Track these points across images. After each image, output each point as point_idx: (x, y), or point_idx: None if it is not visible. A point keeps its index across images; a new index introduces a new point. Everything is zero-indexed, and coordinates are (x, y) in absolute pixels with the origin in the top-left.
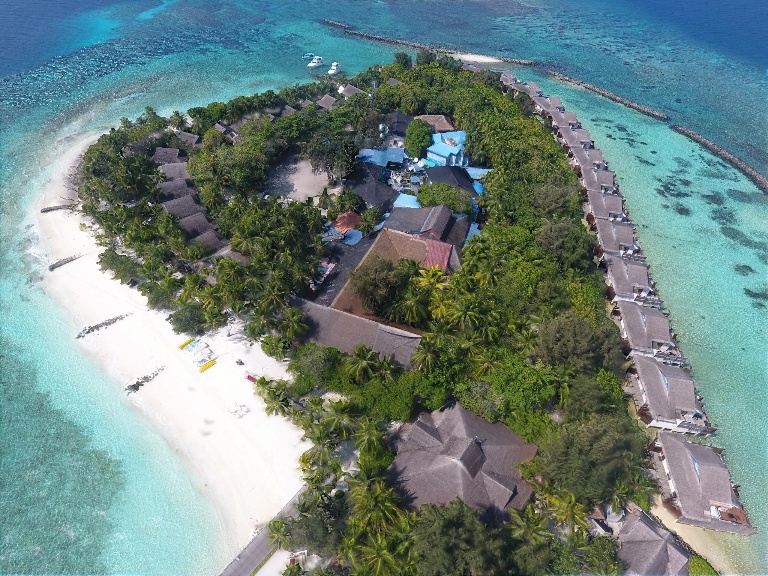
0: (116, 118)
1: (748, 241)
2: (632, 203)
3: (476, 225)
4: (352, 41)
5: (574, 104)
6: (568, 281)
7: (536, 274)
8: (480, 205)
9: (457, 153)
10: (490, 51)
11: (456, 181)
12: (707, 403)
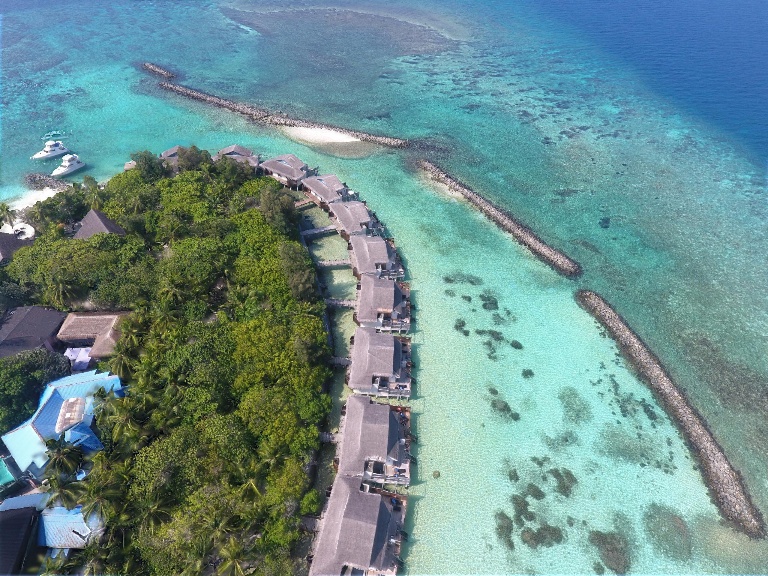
0: None
1: None
2: None
3: None
4: (158, 101)
5: (431, 236)
6: None
7: None
8: None
9: (43, 465)
10: (354, 119)
11: None
12: None
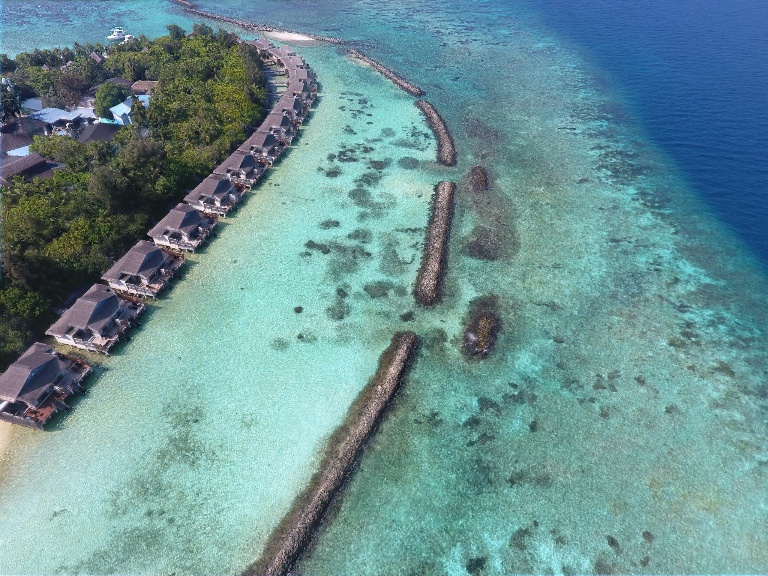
0: None
1: (366, 201)
2: (289, 165)
3: None
4: (184, 18)
5: (342, 79)
6: (81, 219)
7: (46, 211)
8: None
9: (129, 113)
10: (314, 30)
11: (89, 135)
12: (148, 329)
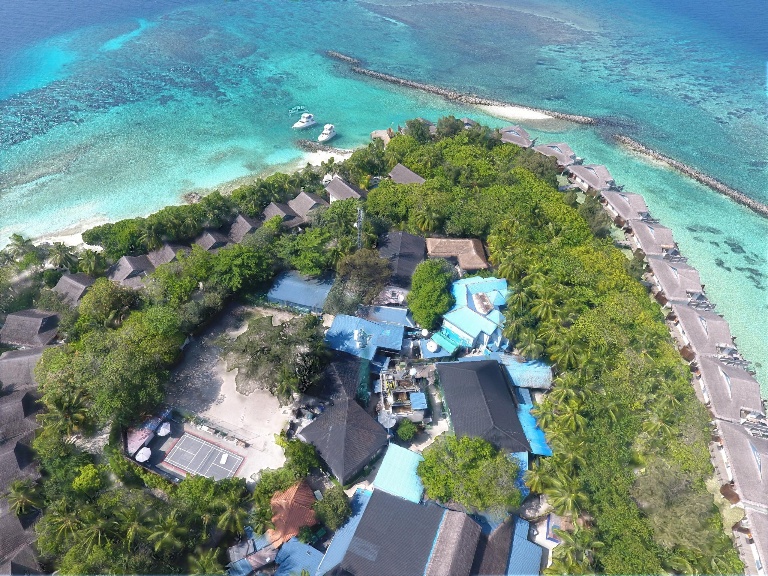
0: (2, 224)
1: None
2: None
3: (525, 528)
4: (358, 83)
5: (658, 196)
6: None
7: None
8: (534, 490)
9: (492, 332)
10: (535, 100)
11: (490, 418)
12: None
